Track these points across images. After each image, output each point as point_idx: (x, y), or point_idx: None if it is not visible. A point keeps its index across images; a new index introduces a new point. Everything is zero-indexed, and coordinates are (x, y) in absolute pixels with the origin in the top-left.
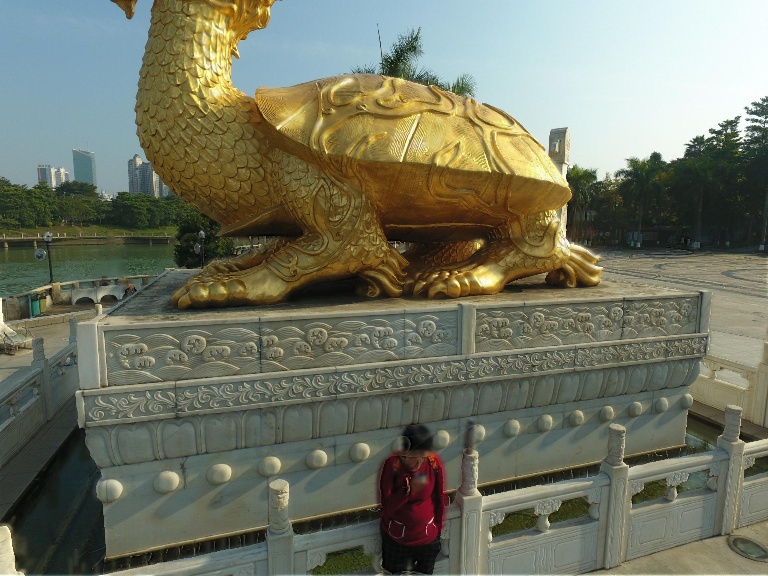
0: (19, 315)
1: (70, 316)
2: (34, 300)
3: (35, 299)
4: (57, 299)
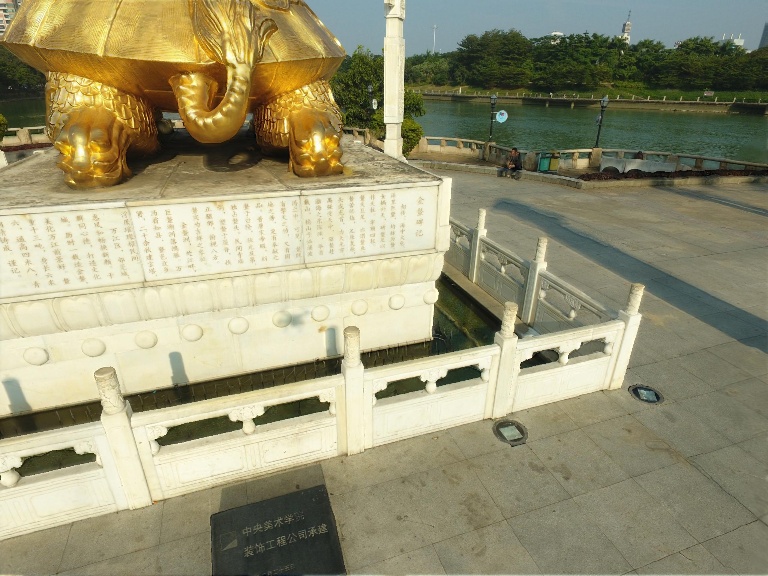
0: (533, 168)
1: (467, 167)
2: (543, 157)
3: (544, 157)
4: (594, 164)
